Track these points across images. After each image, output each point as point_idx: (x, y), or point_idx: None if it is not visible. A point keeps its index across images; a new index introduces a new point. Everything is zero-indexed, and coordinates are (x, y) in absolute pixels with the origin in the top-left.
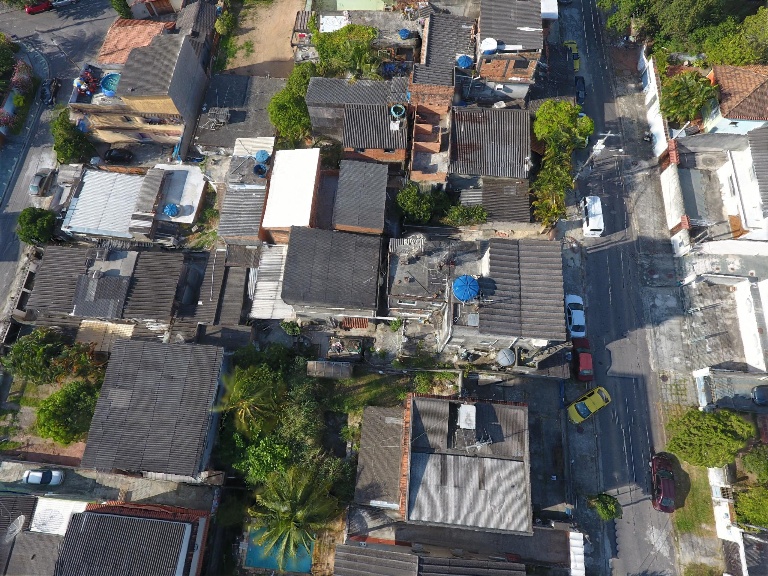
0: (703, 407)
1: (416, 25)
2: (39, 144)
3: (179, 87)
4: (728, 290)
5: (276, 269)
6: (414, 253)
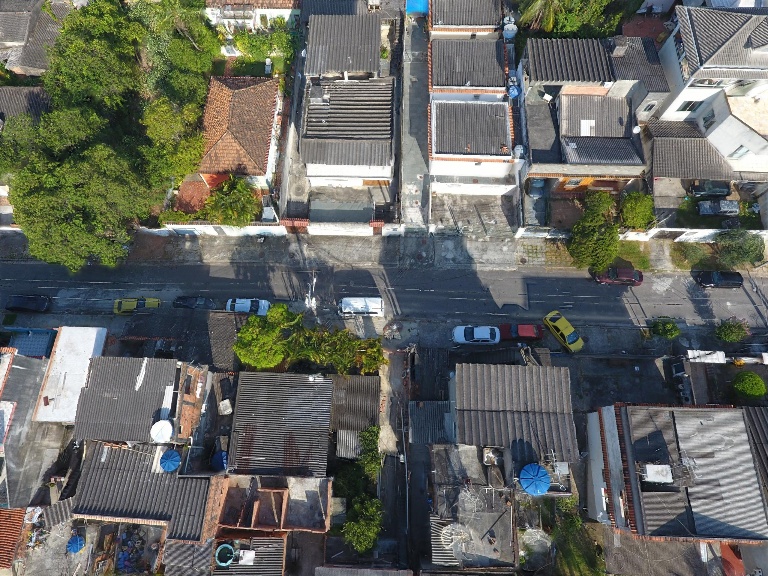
0: (549, 236)
1: None
2: None
3: None
4: (435, 198)
5: None
6: None
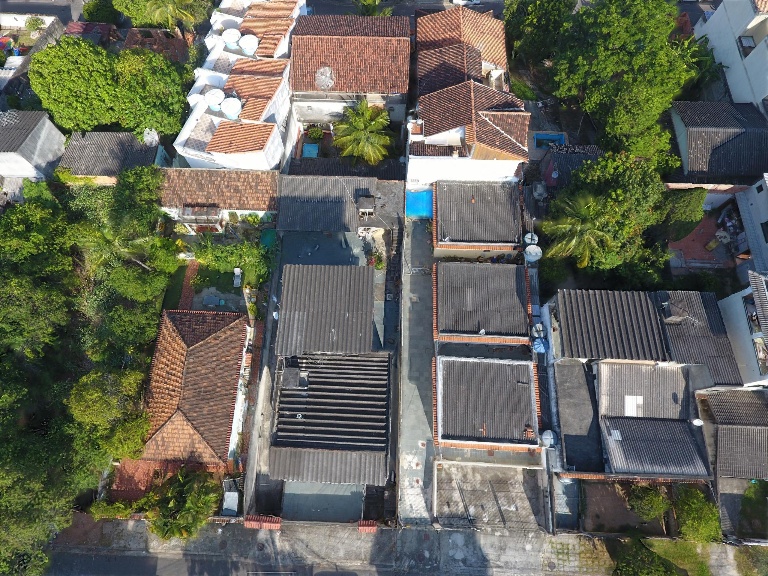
0: None
1: None
2: None
3: None
4: (440, 470)
5: None
6: None
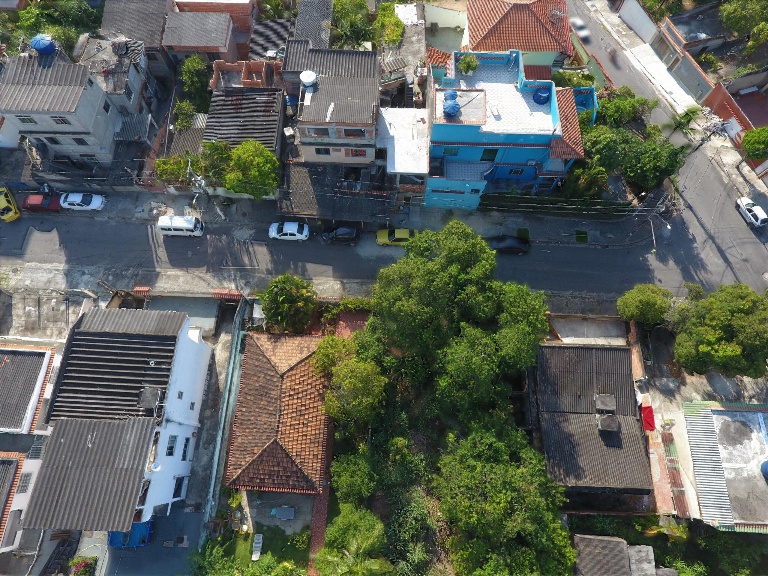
0: None
1: (407, 75)
2: None
3: None
4: None
5: None
6: (117, 46)
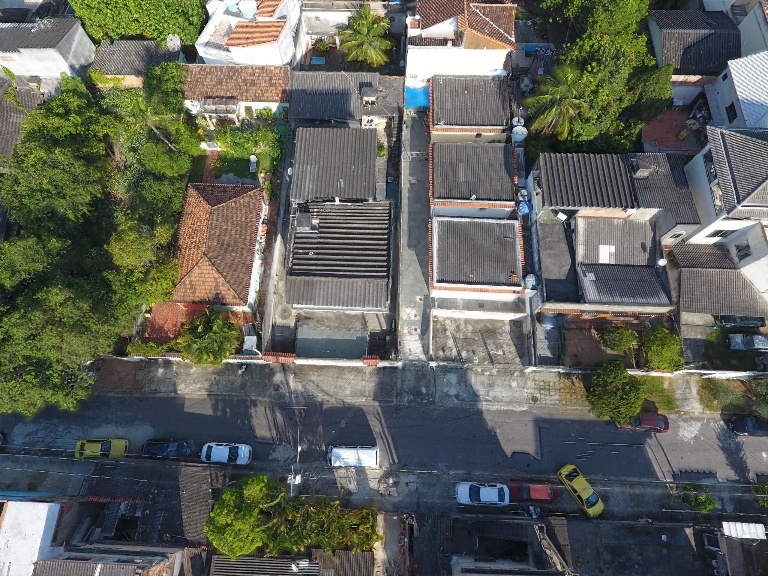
0: None
1: None
2: None
3: None
4: (436, 322)
5: None
6: None
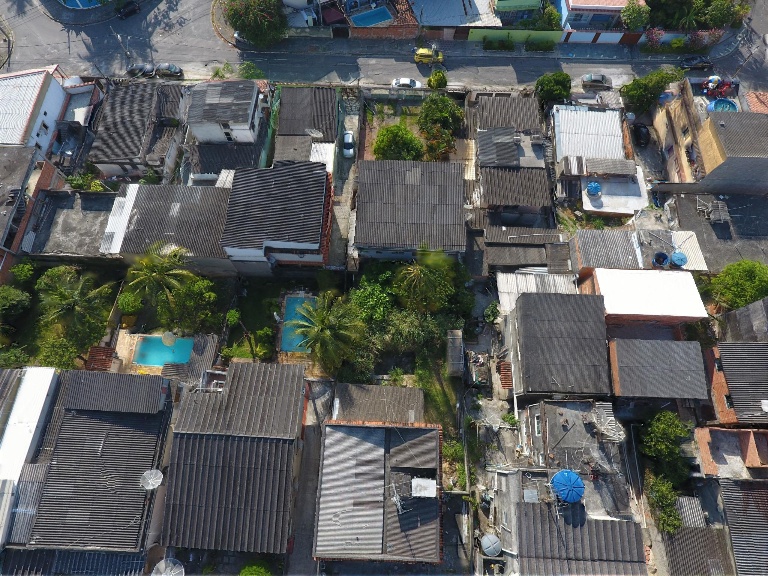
0: None
1: None
2: (635, 70)
3: (741, 167)
4: None
5: (551, 291)
6: (599, 430)
